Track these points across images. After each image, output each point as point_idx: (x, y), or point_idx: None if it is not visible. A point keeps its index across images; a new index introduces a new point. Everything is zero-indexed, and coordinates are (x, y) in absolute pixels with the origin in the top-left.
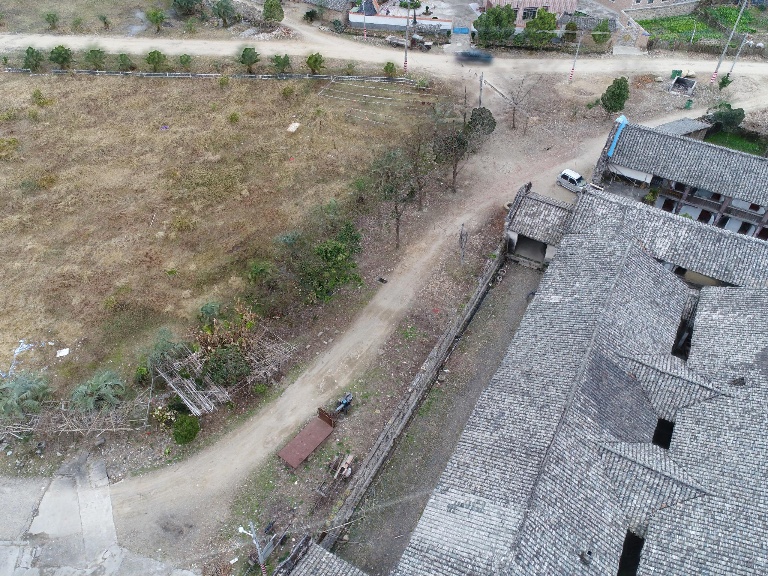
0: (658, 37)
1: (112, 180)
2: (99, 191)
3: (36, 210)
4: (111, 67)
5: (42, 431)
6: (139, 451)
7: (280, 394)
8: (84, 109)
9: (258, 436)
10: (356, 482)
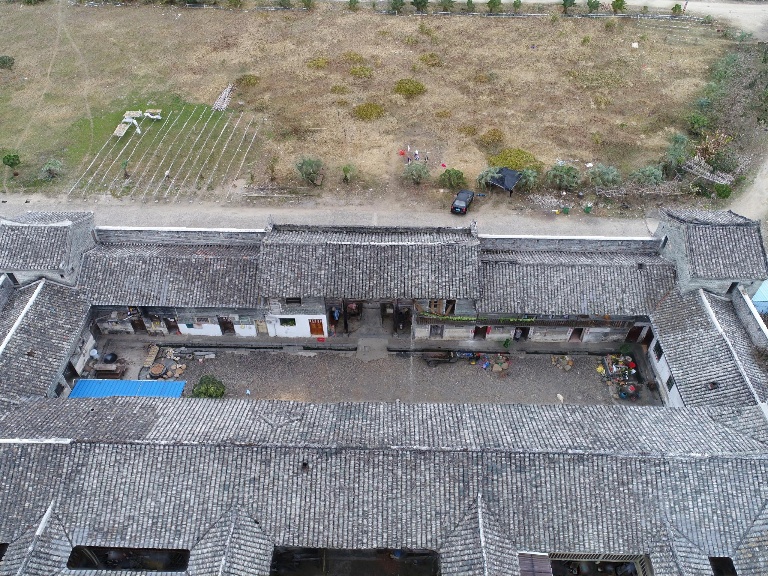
0: None
1: (527, 77)
2: (526, 83)
3: (492, 94)
4: (453, 11)
5: (631, 193)
6: (687, 207)
7: (752, 182)
8: (463, 36)
9: (755, 201)
10: None
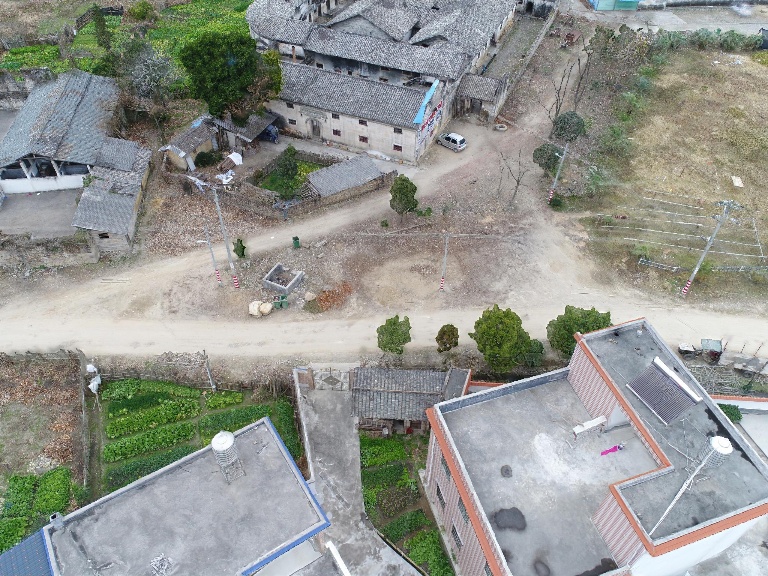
0: (274, 379)
1: None
2: None
3: None
4: None
5: None
6: None
7: None
8: None
9: None
10: (547, 20)
